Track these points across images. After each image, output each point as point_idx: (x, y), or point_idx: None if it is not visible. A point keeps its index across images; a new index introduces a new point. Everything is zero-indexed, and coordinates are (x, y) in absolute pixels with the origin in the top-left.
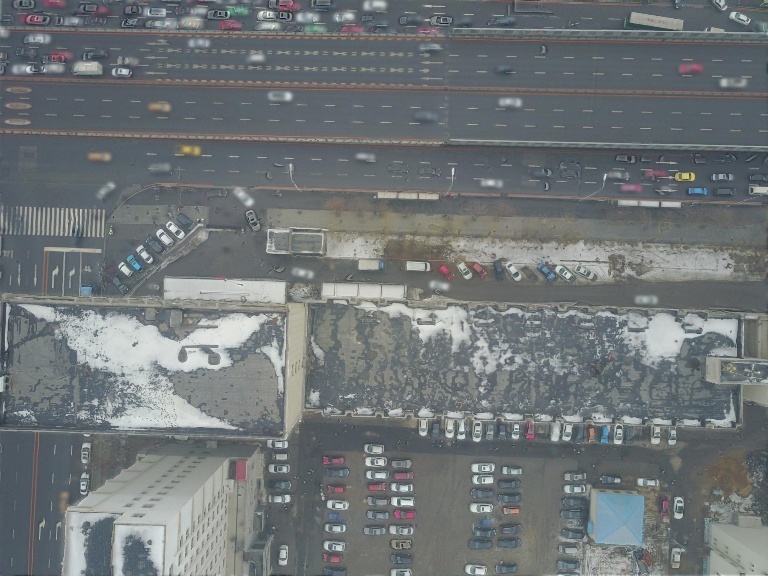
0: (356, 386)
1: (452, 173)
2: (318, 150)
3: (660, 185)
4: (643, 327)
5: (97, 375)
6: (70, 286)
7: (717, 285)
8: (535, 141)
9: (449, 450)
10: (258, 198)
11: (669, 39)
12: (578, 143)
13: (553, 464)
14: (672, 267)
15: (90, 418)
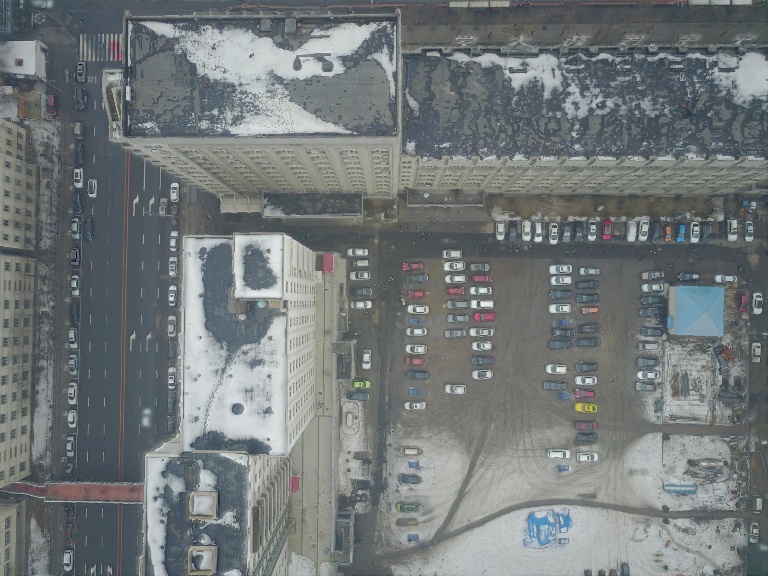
0: (451, 135)
1: None
2: None
3: None
4: (733, 67)
5: (216, 86)
6: None
7: None
8: None
9: (526, 254)
10: None
11: None
12: None
13: (630, 265)
14: None
15: (211, 127)
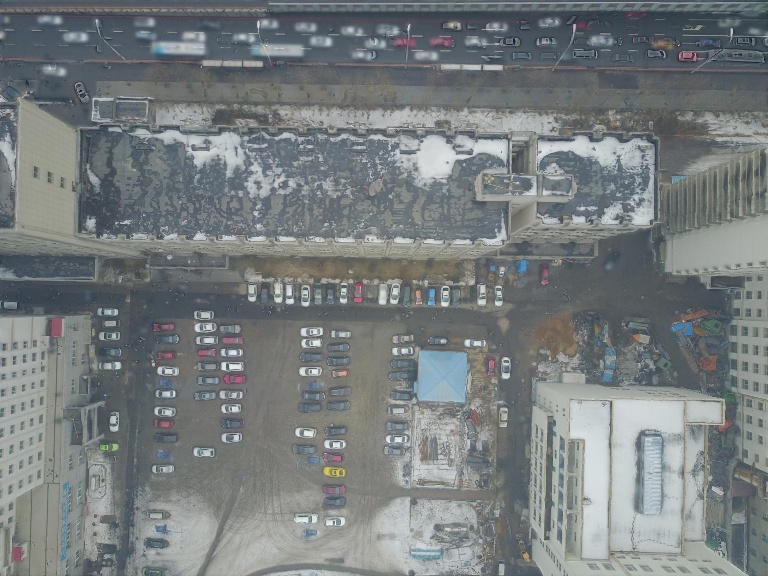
0: (132, 212)
1: (257, 26)
2: (146, 23)
3: (486, 52)
4: (415, 149)
5: None
6: None
7: None
8: (352, 3)
9: (279, 316)
10: (88, 71)
11: None
12: (394, 4)
13: (382, 328)
14: (498, 131)
15: None
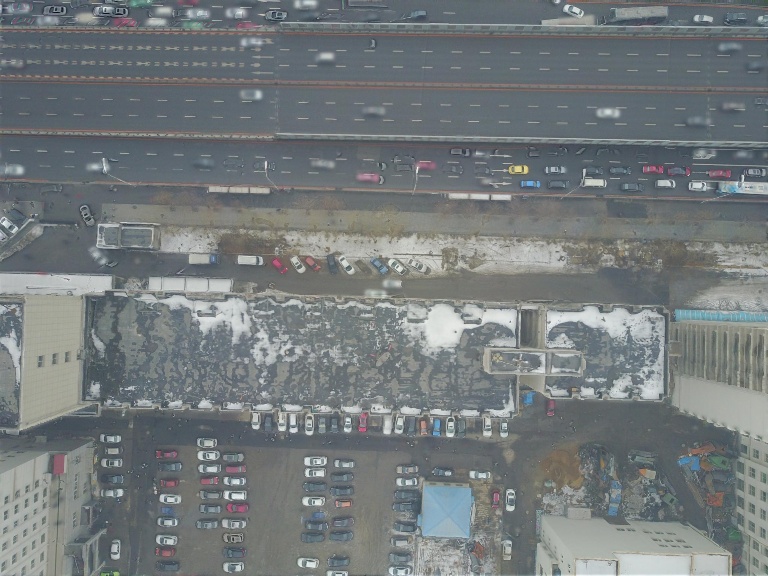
0: (137, 378)
1: (265, 166)
2: (153, 145)
3: (494, 178)
4: (422, 318)
5: None
6: None
7: (550, 278)
8: (360, 134)
9: (282, 444)
10: (93, 193)
11: (497, 32)
12: (403, 136)
13: (386, 457)
14: (505, 260)
15: None
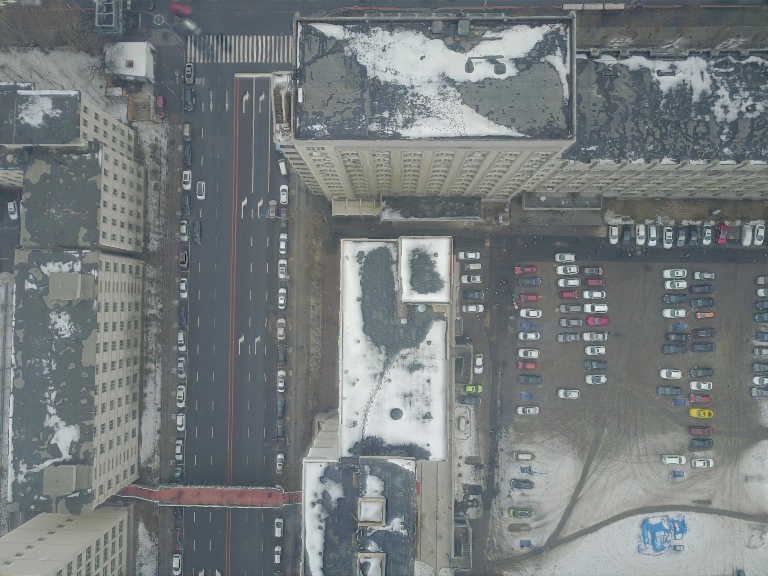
0: (598, 138)
1: None
2: None
3: None
4: None
5: (387, 88)
6: (260, 111)
7: None
8: None
9: (640, 258)
10: None
11: None
12: None
13: (745, 269)
14: None
15: (381, 130)
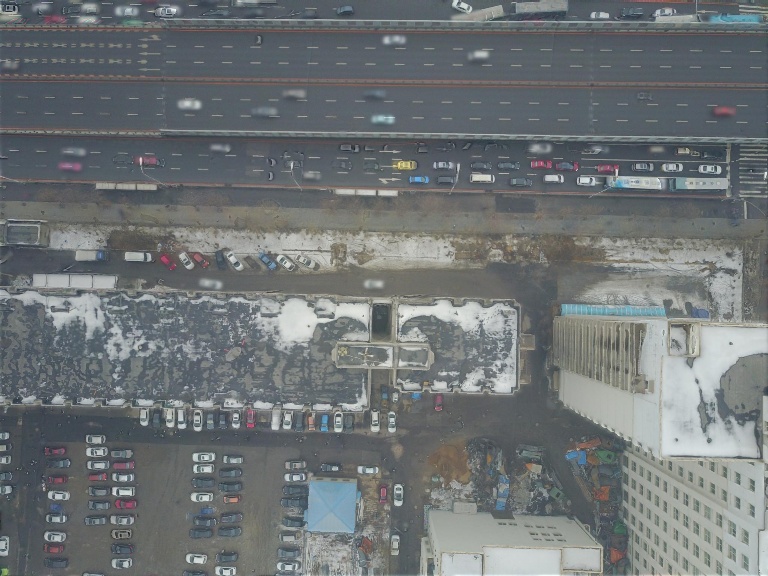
0: None
1: (140, 163)
2: (42, 142)
3: (383, 174)
4: (276, 312)
5: None
6: None
7: (438, 273)
8: (243, 131)
9: (171, 440)
10: None
11: (382, 28)
12: (286, 132)
13: (275, 453)
14: (393, 255)
15: None
